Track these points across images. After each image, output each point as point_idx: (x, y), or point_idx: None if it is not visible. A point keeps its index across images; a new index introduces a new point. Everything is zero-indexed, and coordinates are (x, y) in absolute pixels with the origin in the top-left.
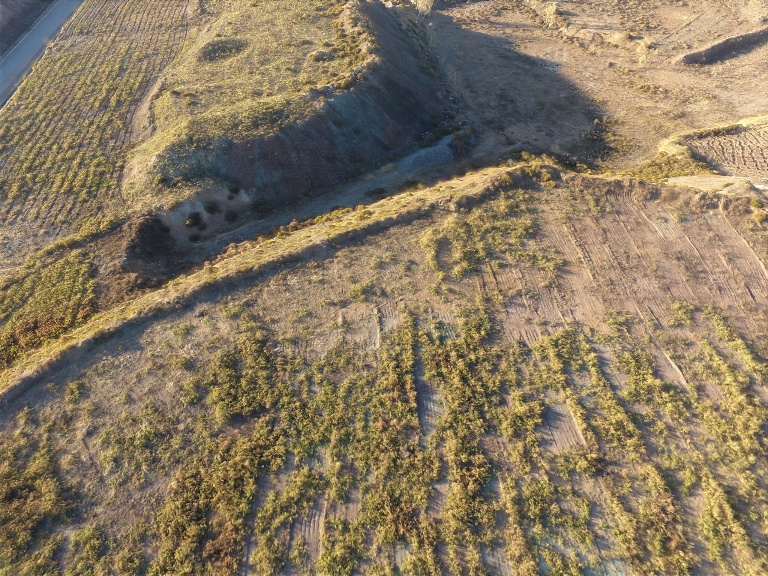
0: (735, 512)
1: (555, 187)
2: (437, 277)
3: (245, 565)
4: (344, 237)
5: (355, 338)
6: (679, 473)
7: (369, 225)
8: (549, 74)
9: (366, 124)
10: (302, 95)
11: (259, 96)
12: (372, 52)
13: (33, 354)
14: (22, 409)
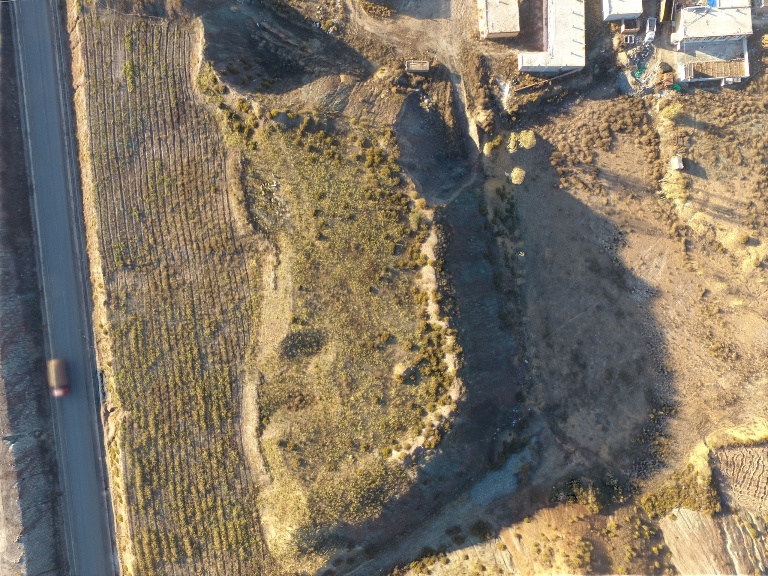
0: None
1: None
2: None
3: None
4: None
5: None
6: None
7: None
8: (634, 314)
9: (450, 469)
10: (398, 464)
11: (357, 449)
12: (459, 376)
13: None
14: None
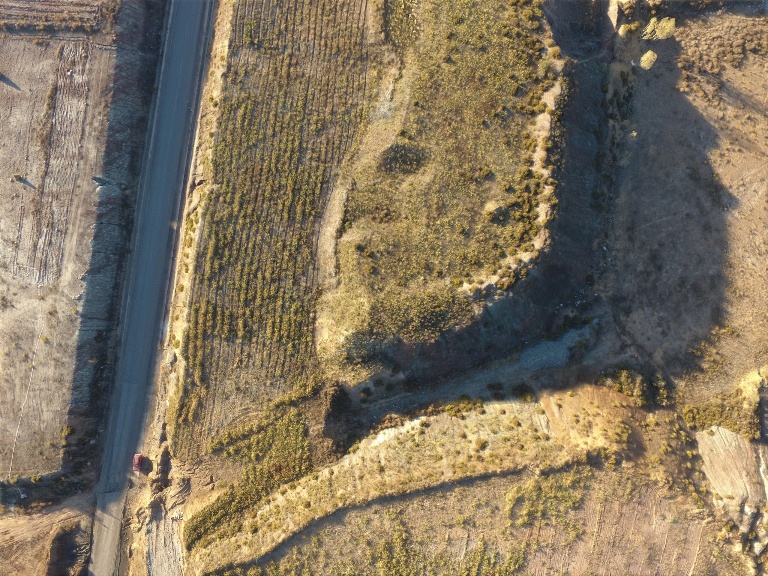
0: None
1: (613, 471)
2: (507, 523)
3: None
4: (463, 479)
5: (452, 550)
6: None
7: (481, 474)
8: (721, 230)
9: (511, 321)
10: (467, 295)
11: (430, 273)
12: (548, 227)
13: (285, 494)
14: (294, 547)
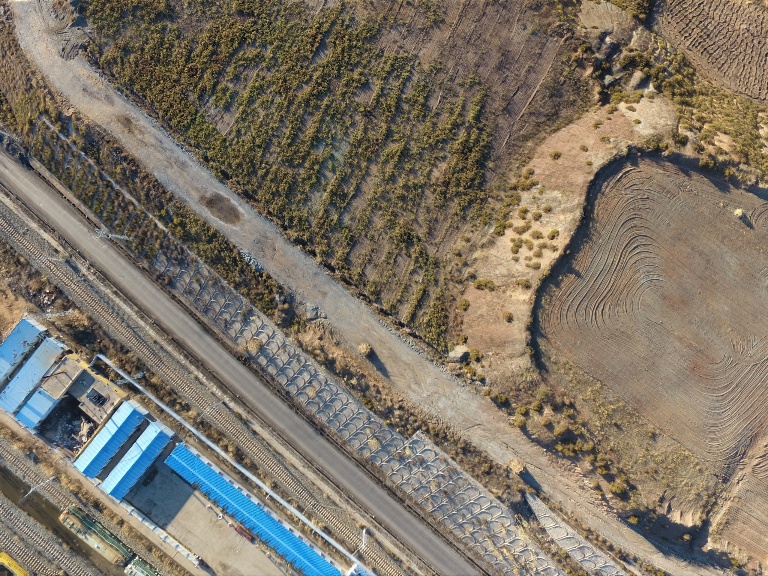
0: (401, 155)
1: None
2: None
3: (224, 70)
4: None
5: (309, 3)
6: (395, 134)
7: None
8: None
9: None
10: None
11: None
12: None
13: None
14: None
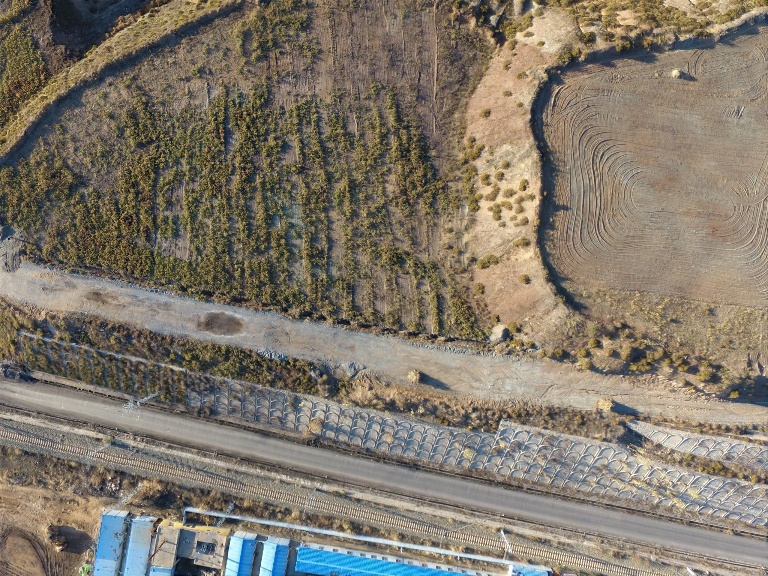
0: (350, 189)
1: None
2: (242, 61)
3: (155, 203)
4: (186, 27)
5: (195, 102)
6: (335, 174)
7: (201, 17)
8: None
9: None
10: None
11: None
12: None
13: (28, 104)
14: (39, 138)
